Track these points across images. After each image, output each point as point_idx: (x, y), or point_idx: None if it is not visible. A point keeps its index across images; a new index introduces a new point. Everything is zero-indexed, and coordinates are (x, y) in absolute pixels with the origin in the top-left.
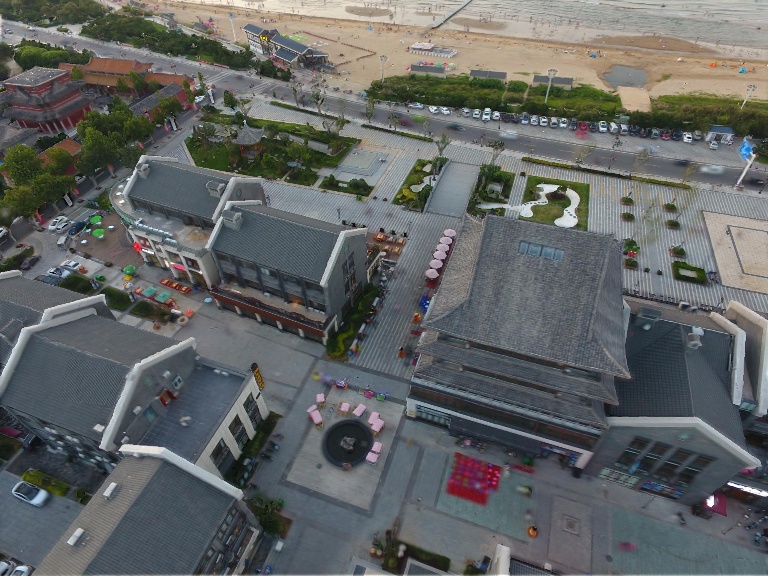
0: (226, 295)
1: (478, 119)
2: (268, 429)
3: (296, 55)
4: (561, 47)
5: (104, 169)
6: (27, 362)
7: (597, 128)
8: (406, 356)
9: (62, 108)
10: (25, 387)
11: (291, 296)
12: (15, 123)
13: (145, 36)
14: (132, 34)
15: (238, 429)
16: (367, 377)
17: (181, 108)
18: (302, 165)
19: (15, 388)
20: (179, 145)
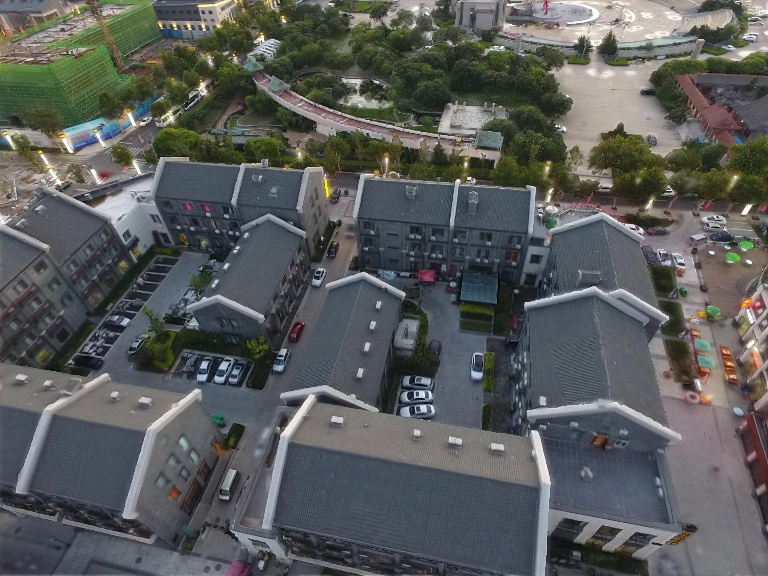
0: (762, 435)
1: None
2: (624, 567)
3: None
4: None
5: None
6: (569, 308)
7: None
8: None
9: None
10: (549, 320)
11: None
12: None
13: None
14: None
15: (606, 534)
16: None
17: None
18: None
19: (545, 313)
20: None
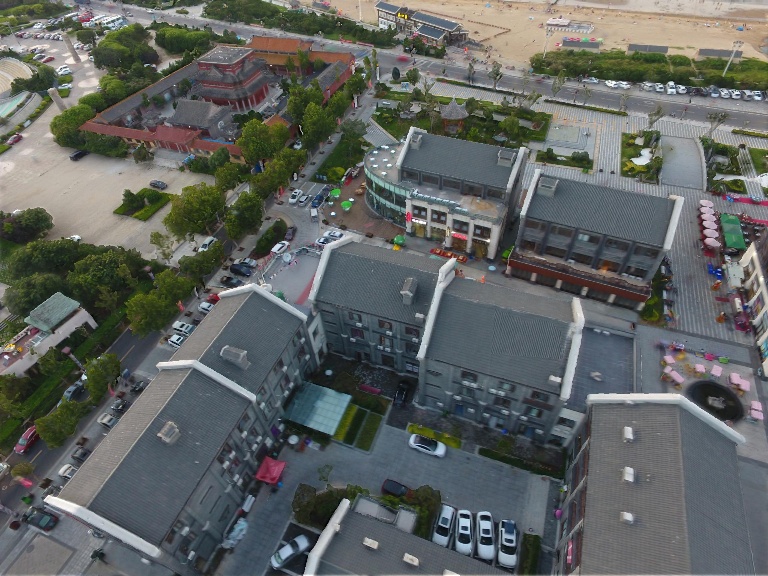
0: (528, 262)
1: (662, 93)
2: None
3: (443, 32)
4: (700, 21)
5: None
6: (446, 318)
7: None
8: (725, 321)
9: (250, 86)
10: (451, 342)
11: (602, 262)
12: None
13: None
14: (256, 15)
15: None
16: (696, 341)
17: (365, 85)
18: None
19: (439, 343)
20: (368, 121)
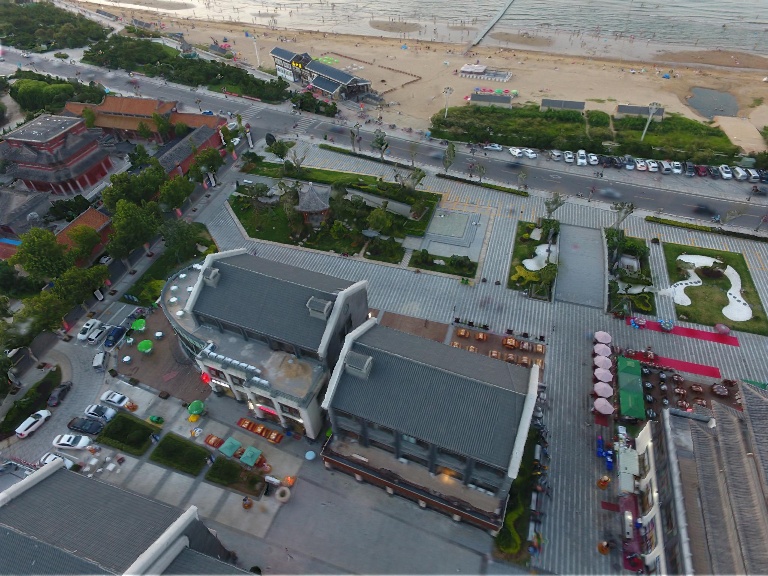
0: (345, 462)
1: (571, 163)
2: None
3: (338, 85)
4: (626, 66)
5: None
6: None
7: (719, 174)
8: (610, 551)
9: (77, 164)
10: None
11: (441, 467)
12: (19, 181)
13: None
14: (141, 60)
15: None
16: None
17: (221, 160)
18: (381, 234)
19: None
20: (222, 207)
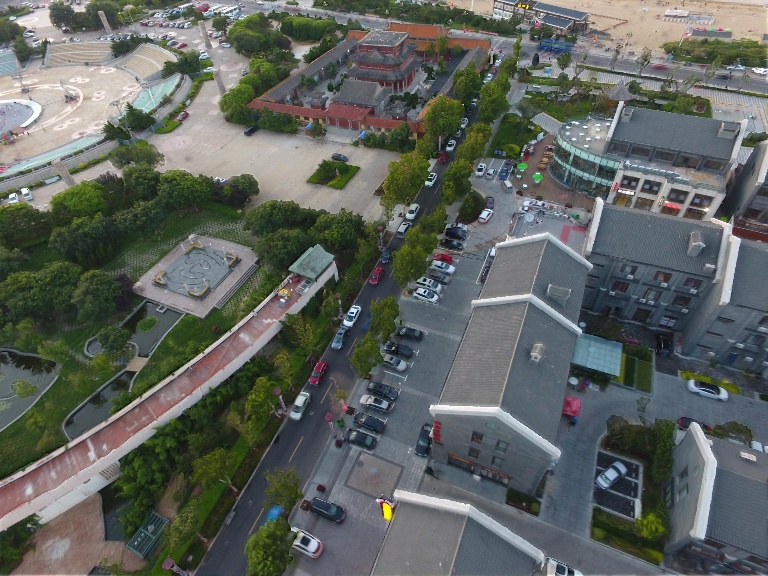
0: (756, 229)
1: None
2: None
3: (570, 21)
4: None
5: (469, 125)
6: (745, 267)
7: None
8: None
9: (405, 68)
10: (753, 289)
11: None
12: None
13: (403, 5)
14: (368, 5)
15: None
16: None
17: None
18: None
19: (741, 290)
20: None
